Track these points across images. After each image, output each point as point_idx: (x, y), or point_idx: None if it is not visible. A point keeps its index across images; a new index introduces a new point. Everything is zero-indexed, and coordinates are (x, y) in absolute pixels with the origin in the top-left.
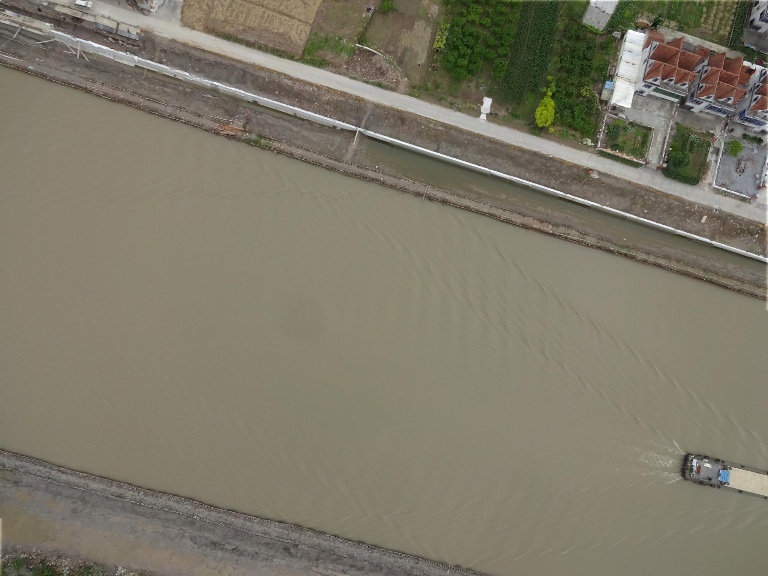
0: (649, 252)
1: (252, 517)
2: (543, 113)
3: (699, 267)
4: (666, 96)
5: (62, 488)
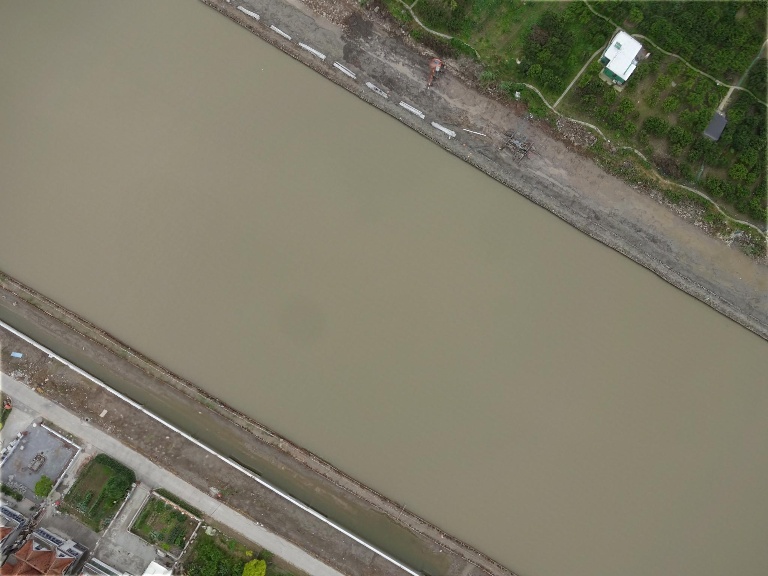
0: (179, 393)
1: (623, 253)
2: (258, 575)
3: (129, 363)
4: (105, 567)
5: (766, 322)
